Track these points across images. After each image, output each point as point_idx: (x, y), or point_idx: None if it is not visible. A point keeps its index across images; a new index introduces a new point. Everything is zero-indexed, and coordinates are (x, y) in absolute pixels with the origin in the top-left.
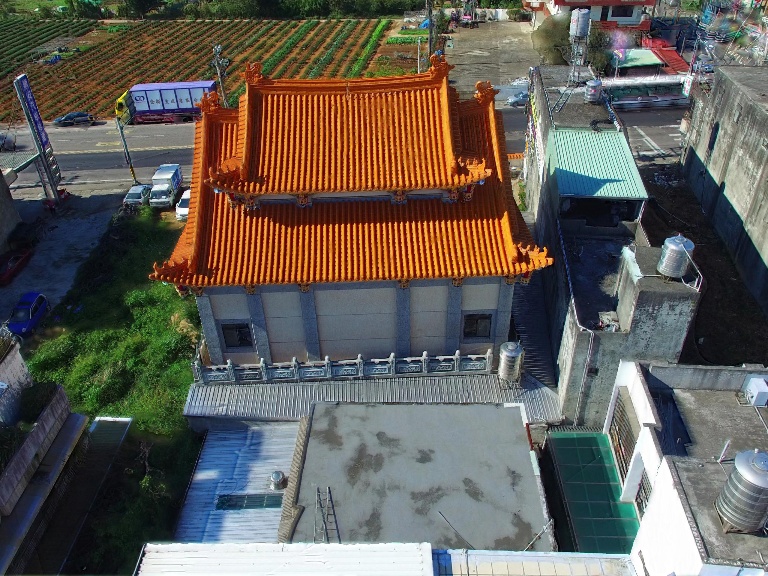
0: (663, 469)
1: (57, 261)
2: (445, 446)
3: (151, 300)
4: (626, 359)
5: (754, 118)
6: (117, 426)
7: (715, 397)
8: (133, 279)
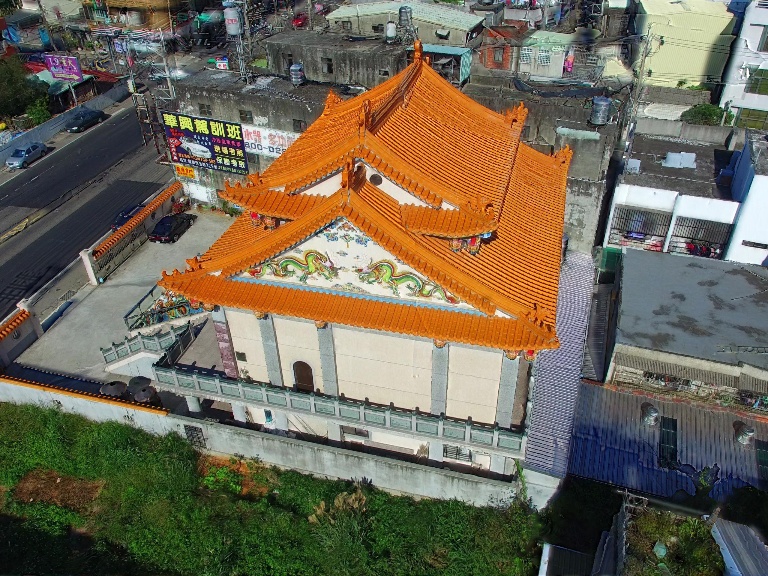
0: (759, 181)
1: None
2: (667, 286)
3: None
4: (617, 185)
5: (356, 61)
6: (558, 559)
7: (631, 180)
8: None
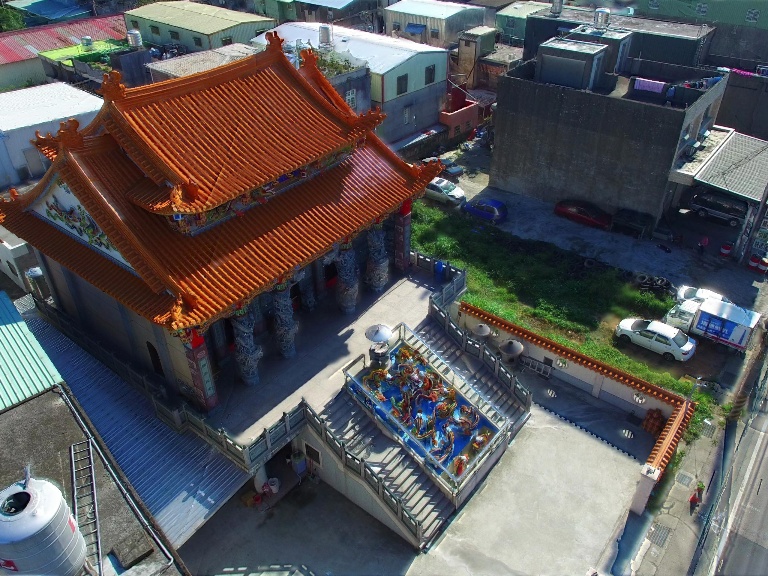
0: None
1: (583, 240)
2: None
3: (441, 255)
4: None
5: None
6: None
7: None
8: (495, 259)
